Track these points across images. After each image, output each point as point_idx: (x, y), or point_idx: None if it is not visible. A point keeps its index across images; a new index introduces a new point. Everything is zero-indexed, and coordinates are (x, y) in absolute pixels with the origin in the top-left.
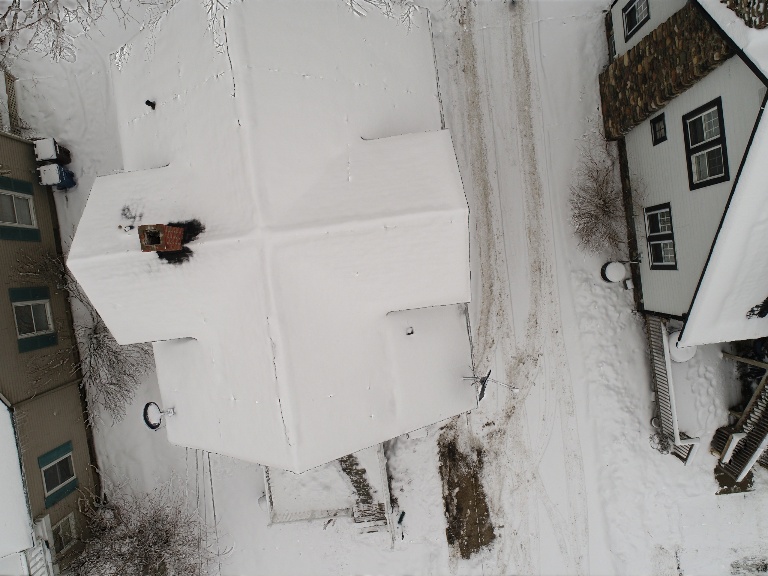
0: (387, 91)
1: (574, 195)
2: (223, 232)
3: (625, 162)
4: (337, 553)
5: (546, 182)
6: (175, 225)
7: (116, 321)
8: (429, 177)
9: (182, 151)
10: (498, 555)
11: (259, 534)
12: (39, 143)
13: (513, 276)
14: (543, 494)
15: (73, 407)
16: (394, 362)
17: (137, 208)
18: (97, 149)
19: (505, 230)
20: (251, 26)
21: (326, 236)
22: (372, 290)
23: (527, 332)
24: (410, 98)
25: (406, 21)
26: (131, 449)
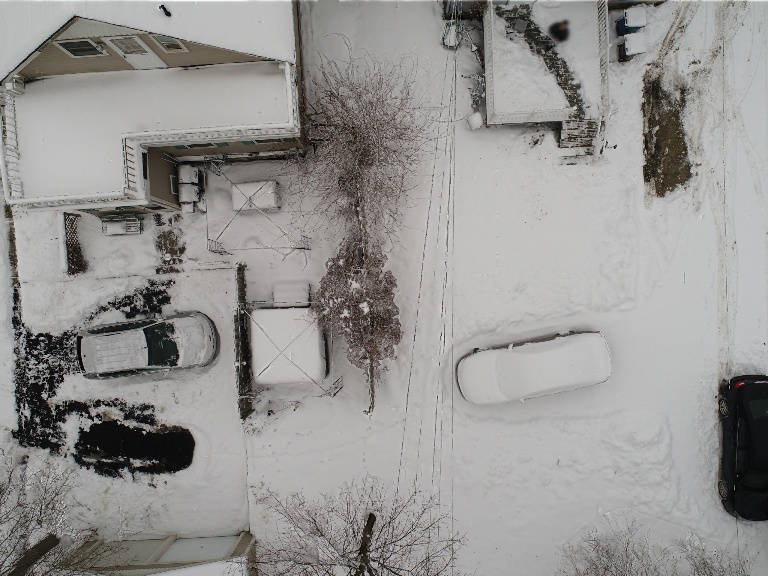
0: None
1: None
2: None
3: None
4: (535, 183)
5: None
6: None
7: None
8: None
9: None
10: (693, 193)
11: (458, 163)
12: None
13: None
14: (742, 134)
15: (295, 12)
16: None
17: None
18: None
19: None
20: None
21: None
22: None
23: None
24: None
25: None
26: None
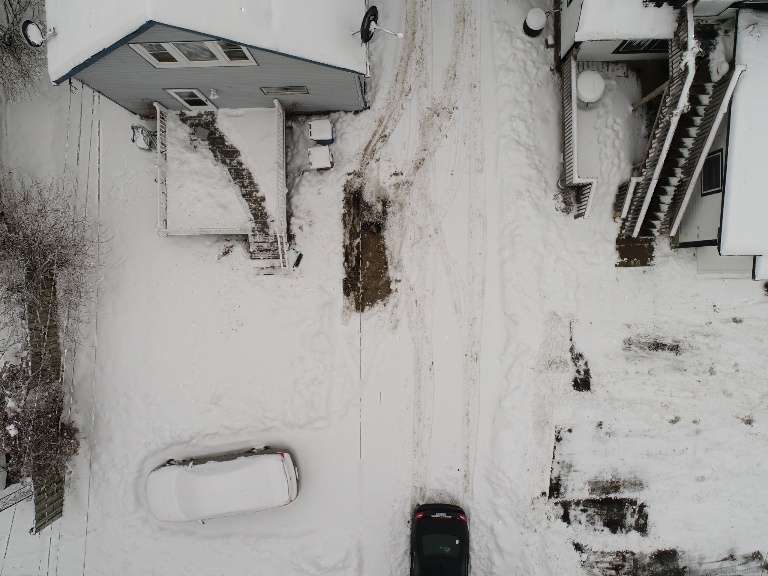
0: None
1: None
2: None
3: None
4: (230, 293)
5: None
6: None
7: None
8: None
9: None
10: (392, 310)
11: (154, 268)
12: None
13: (436, 24)
14: (443, 250)
15: None
16: None
17: None
18: None
19: None
20: None
21: None
22: None
23: (445, 83)
24: None
25: None
26: (34, 168)
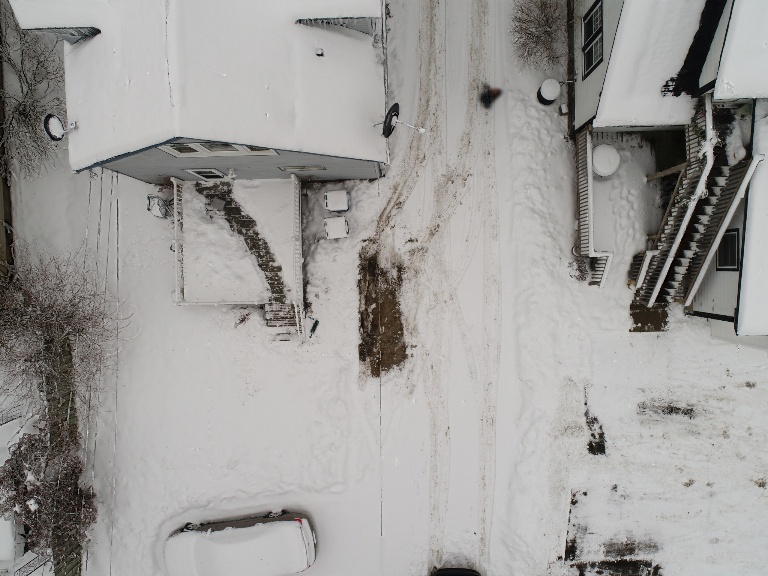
0: None
1: None
2: None
3: None
4: (247, 359)
5: (493, 0)
6: None
7: None
8: None
9: None
10: (408, 375)
11: (170, 334)
12: None
13: (451, 92)
14: (459, 316)
15: None
16: (299, 75)
17: None
18: None
19: (447, 44)
20: None
21: None
22: None
23: (459, 150)
24: None
25: None
26: (49, 235)
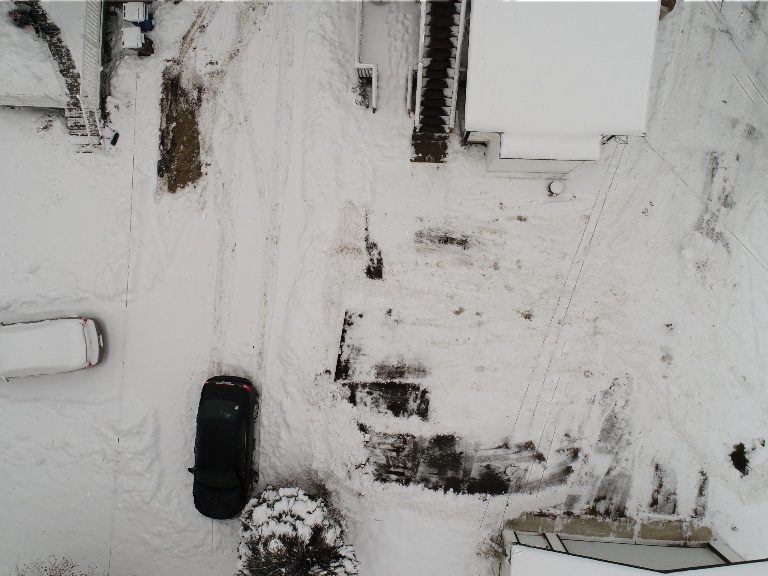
0: None
1: None
2: None
3: None
4: (52, 167)
5: None
6: None
7: None
8: None
9: None
10: (201, 192)
11: None
12: None
13: None
14: (252, 138)
15: None
16: None
17: None
18: None
19: None
20: None
21: None
22: None
23: None
24: None
25: None
26: None
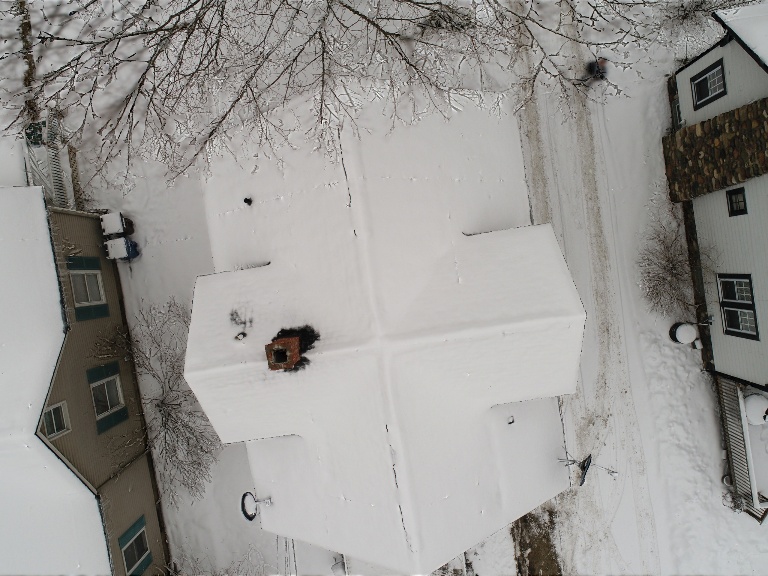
0: (483, 183)
1: (643, 259)
2: (340, 340)
3: (692, 224)
4: None
5: (612, 244)
6: (288, 332)
7: (225, 424)
8: (541, 279)
9: (285, 251)
10: None
11: None
12: (106, 217)
13: None
14: (616, 553)
15: (144, 479)
16: (498, 454)
17: (246, 313)
18: (160, 219)
19: None
20: (365, 136)
21: (444, 343)
22: (481, 388)
23: (596, 393)
24: (503, 187)
25: (496, 110)
26: (200, 518)
